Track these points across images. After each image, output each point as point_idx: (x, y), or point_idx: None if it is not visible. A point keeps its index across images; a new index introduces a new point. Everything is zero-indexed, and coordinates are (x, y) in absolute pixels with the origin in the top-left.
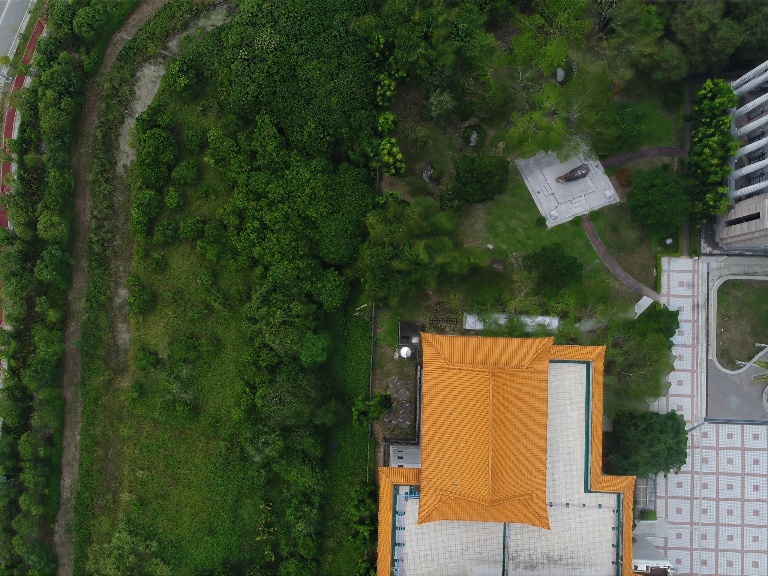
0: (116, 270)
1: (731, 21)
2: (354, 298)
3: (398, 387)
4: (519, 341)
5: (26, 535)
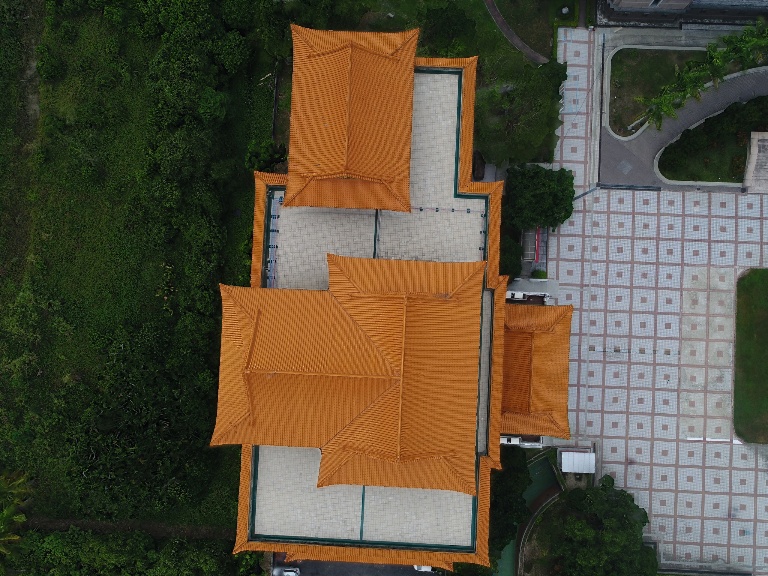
0: (28, 42)
1: None
2: (259, 68)
3: None
4: (387, 35)
5: None
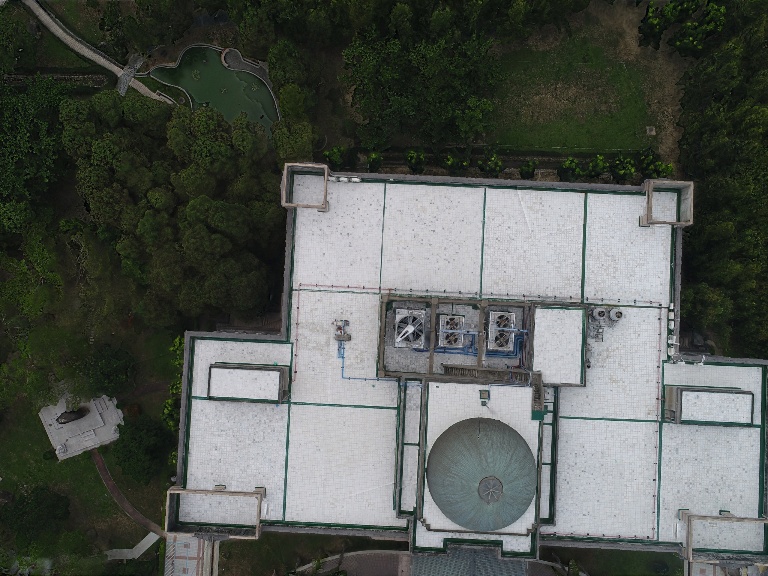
0: None
1: (194, 282)
2: None
3: None
4: None
5: None
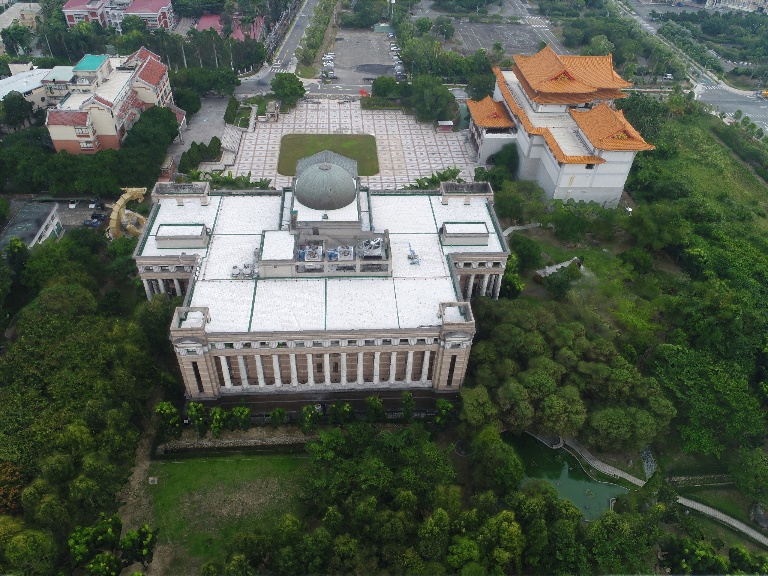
0: None
1: None
2: None
3: (623, 204)
4: (609, 149)
5: (765, 155)
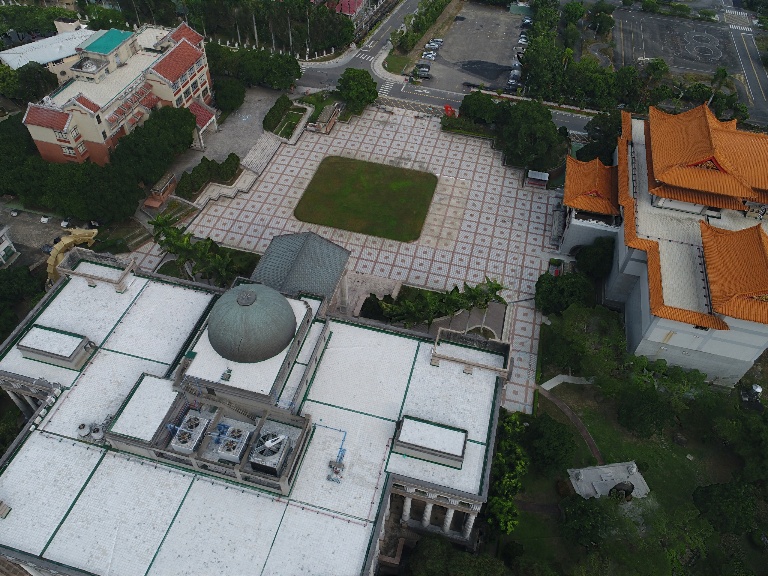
0: None
1: None
2: None
3: (753, 371)
4: (738, 316)
5: None
